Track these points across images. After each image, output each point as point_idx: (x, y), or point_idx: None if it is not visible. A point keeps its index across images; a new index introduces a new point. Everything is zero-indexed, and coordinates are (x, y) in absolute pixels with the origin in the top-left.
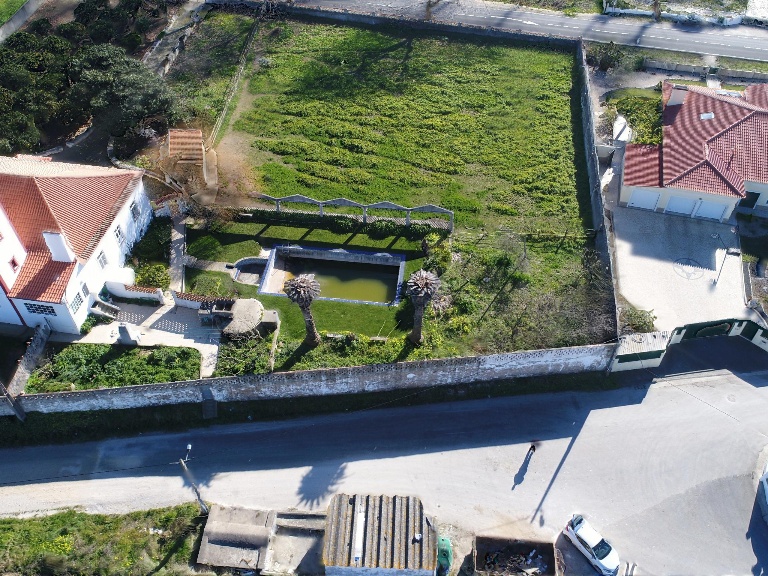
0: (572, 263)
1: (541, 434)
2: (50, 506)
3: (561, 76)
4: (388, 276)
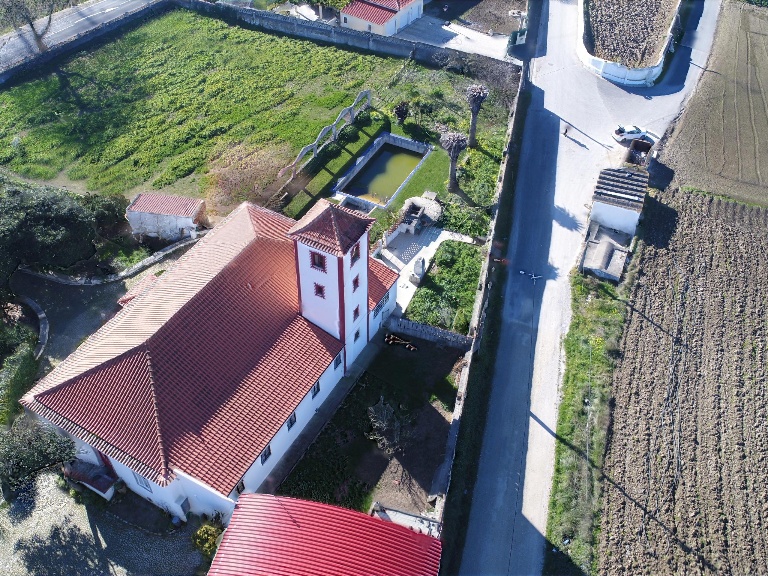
0: (429, 73)
1: (555, 128)
2: (557, 353)
3: (204, 21)
4: (386, 154)
